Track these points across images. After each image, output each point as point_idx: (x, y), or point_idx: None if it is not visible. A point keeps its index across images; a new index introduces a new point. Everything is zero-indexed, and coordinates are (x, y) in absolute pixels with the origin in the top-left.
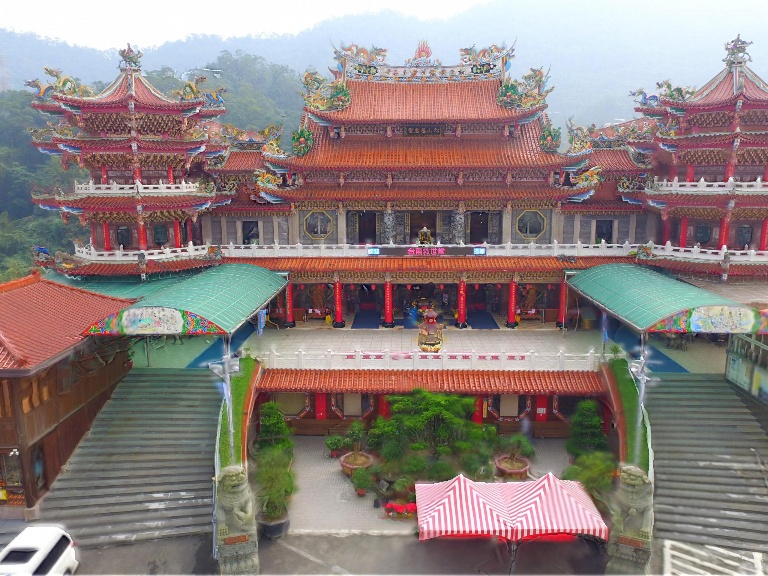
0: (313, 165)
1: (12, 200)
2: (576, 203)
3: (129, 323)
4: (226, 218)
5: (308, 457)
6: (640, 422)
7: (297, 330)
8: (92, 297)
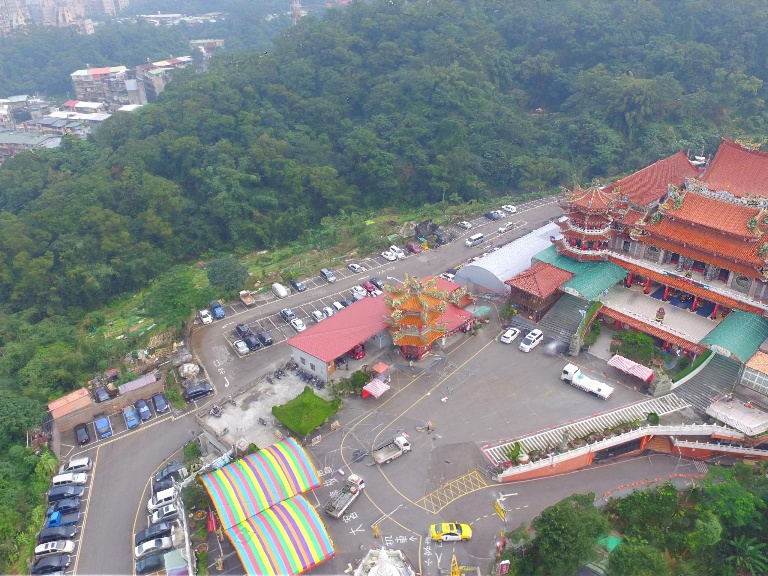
0: (654, 232)
1: (550, 92)
2: (761, 281)
3: (567, 290)
4: (619, 238)
5: (606, 336)
6: (692, 367)
7: (630, 289)
8: (562, 272)
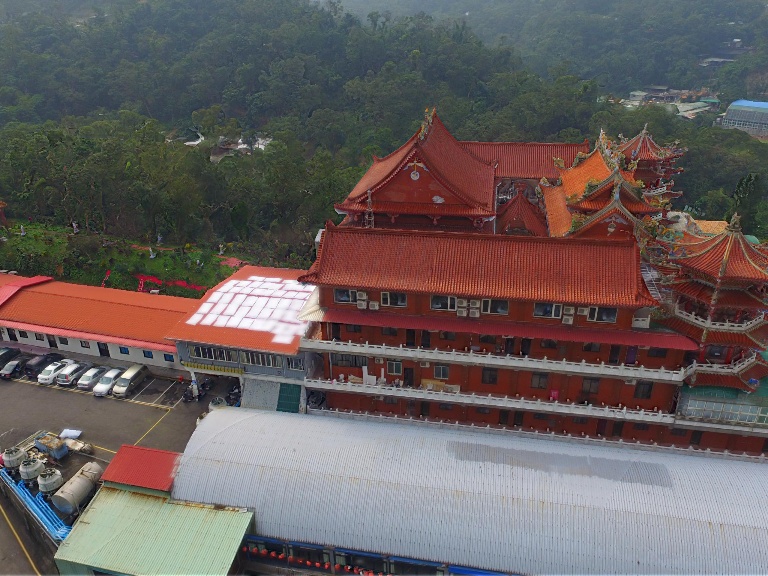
0: None
1: None
2: None
3: None
4: None
5: None
6: None
7: None
8: None
